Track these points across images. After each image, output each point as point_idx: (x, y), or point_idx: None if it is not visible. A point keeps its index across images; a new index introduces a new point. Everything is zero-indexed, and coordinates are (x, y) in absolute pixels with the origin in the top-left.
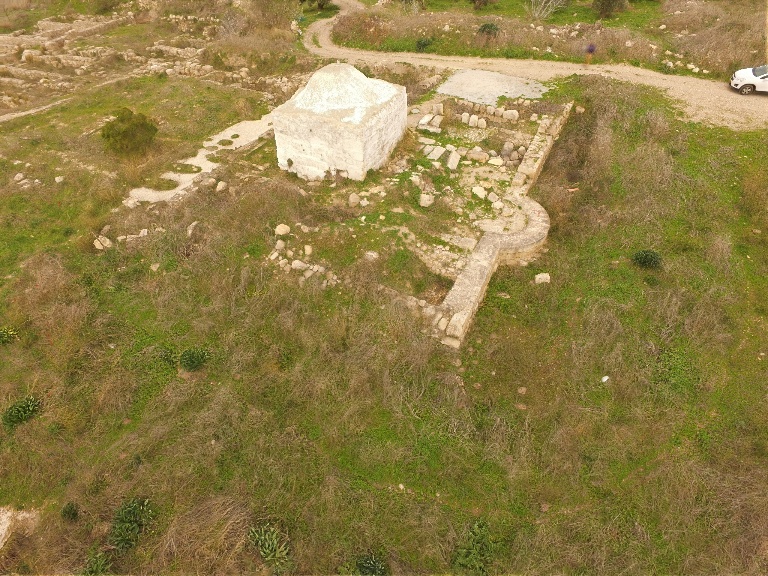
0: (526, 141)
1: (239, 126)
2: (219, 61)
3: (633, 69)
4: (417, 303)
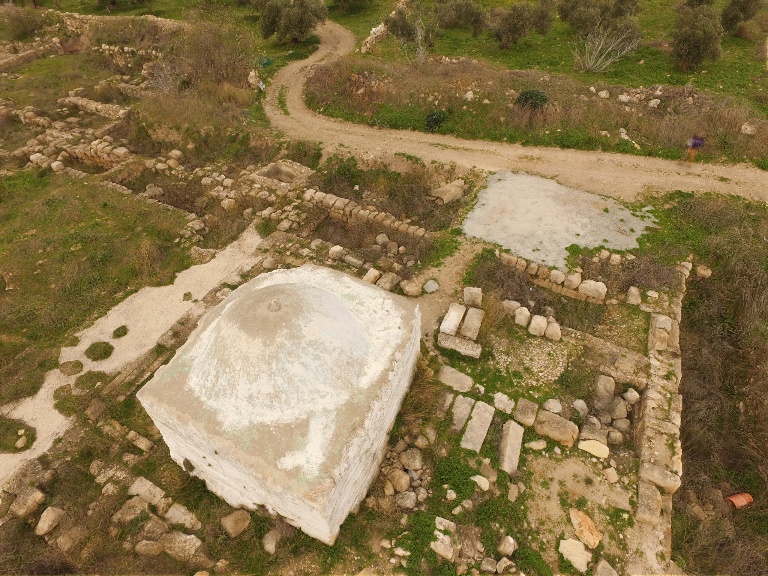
0: (638, 377)
1: (133, 303)
2: (143, 135)
3: (761, 175)
4: None
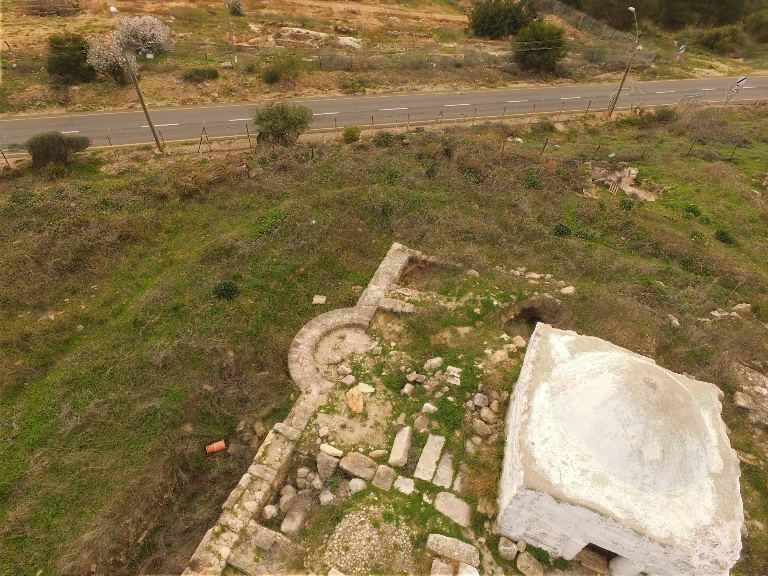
0: (256, 527)
1: None
2: None
3: None
4: (428, 257)
